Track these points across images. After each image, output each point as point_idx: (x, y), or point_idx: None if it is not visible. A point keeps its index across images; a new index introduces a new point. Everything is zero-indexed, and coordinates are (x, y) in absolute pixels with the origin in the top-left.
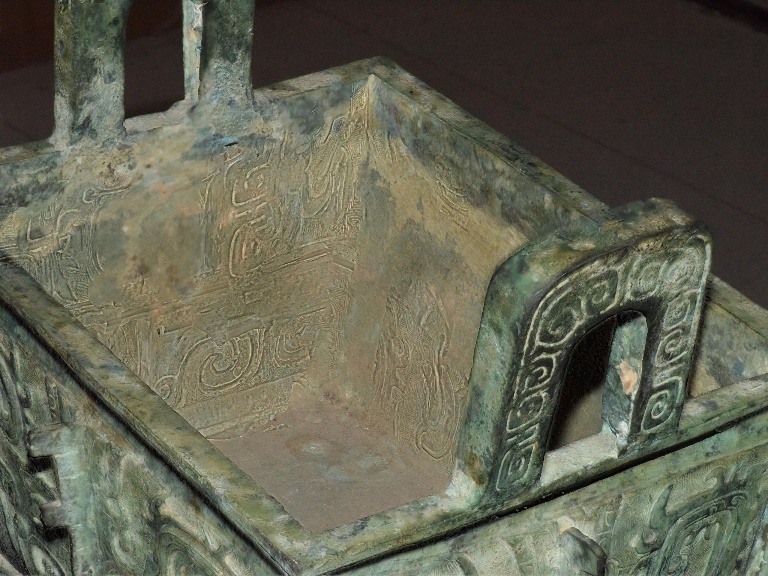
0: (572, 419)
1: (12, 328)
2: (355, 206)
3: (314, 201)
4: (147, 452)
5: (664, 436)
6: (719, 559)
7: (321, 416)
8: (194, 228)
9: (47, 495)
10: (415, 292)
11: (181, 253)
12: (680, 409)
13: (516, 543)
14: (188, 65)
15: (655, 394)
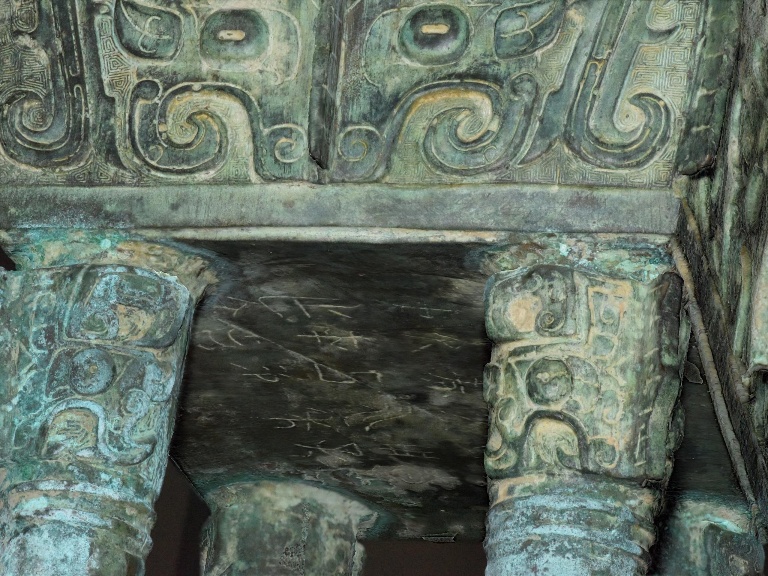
0: None
1: None
2: None
3: None
4: None
5: None
6: None
7: None
8: None
9: None
10: None
11: None
12: None
13: None
14: None
15: None
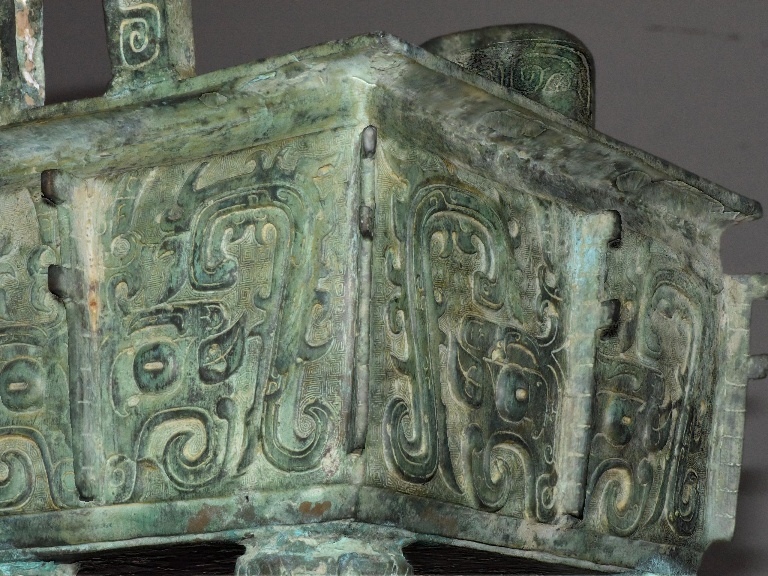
0: None
1: None
2: None
3: None
4: None
5: (158, 80)
6: (285, 277)
7: None
8: None
9: None
10: None
11: None
12: (166, 47)
13: (34, 191)
14: None
15: (128, 20)
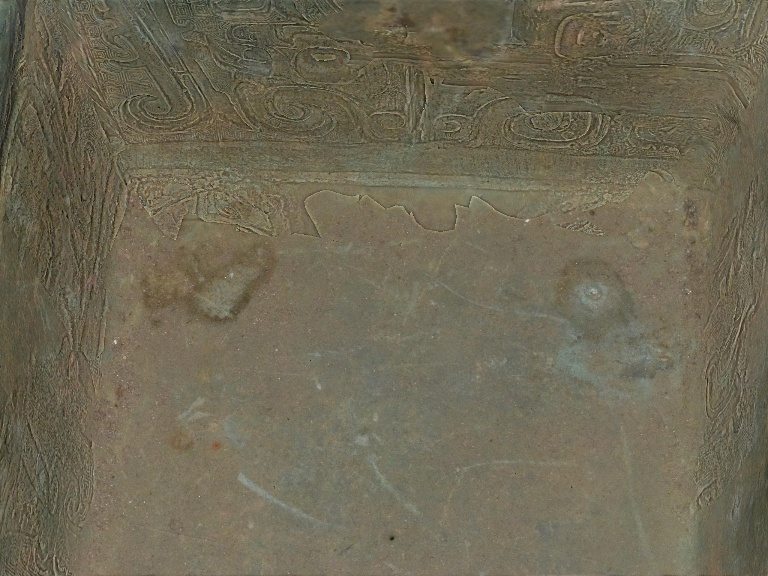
0: (750, 575)
1: None
2: (765, 44)
3: (705, 16)
4: None
5: None
6: None
7: (652, 237)
8: (494, 1)
9: None
10: (761, 215)
11: (472, 19)
12: None
13: None
14: None
15: None
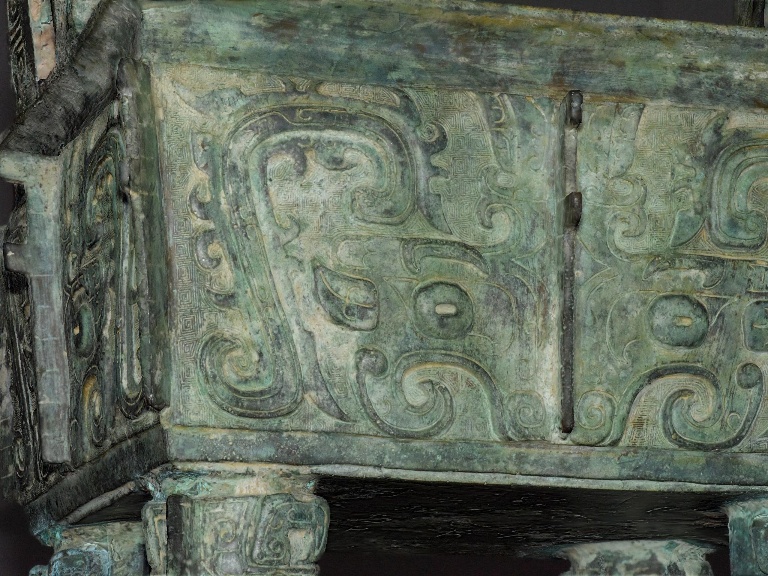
0: None
1: (384, 77)
2: None
3: None
4: (669, 94)
5: None
6: None
7: None
8: None
9: (468, 258)
10: None
11: None
12: None
13: None
14: (34, 44)
15: None
